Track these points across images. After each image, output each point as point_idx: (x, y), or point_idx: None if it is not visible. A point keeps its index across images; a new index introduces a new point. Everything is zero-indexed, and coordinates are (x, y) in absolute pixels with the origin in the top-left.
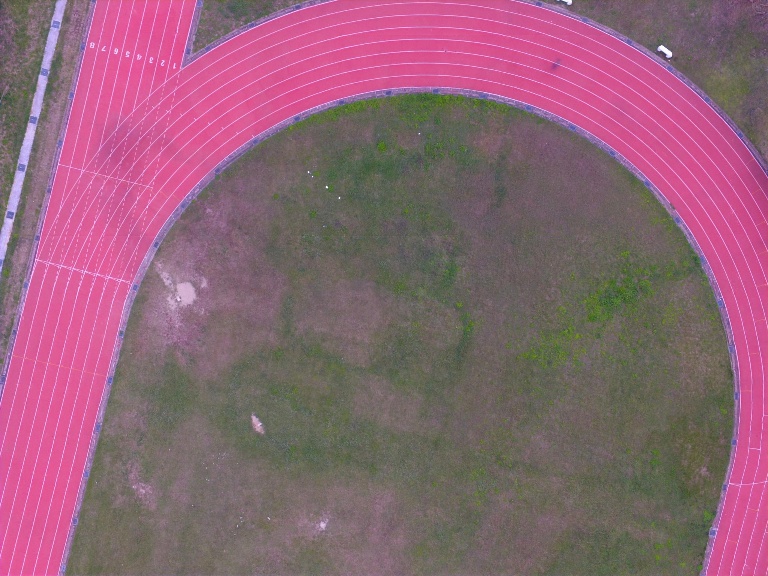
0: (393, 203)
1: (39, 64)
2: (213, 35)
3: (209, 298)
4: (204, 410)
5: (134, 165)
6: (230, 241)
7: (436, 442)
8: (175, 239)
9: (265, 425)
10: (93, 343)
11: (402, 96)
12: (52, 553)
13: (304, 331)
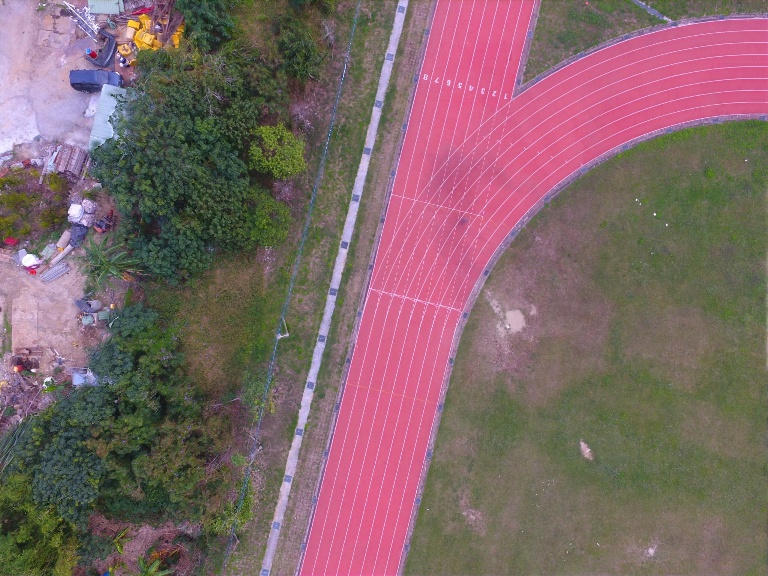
0: (720, 229)
1: (374, 96)
2: (543, 65)
3: (538, 325)
4: (534, 437)
5: (465, 194)
6: (559, 269)
7: (764, 467)
8: (505, 267)
9: (594, 451)
10: (424, 371)
11: (729, 123)
12: None
13: (632, 357)
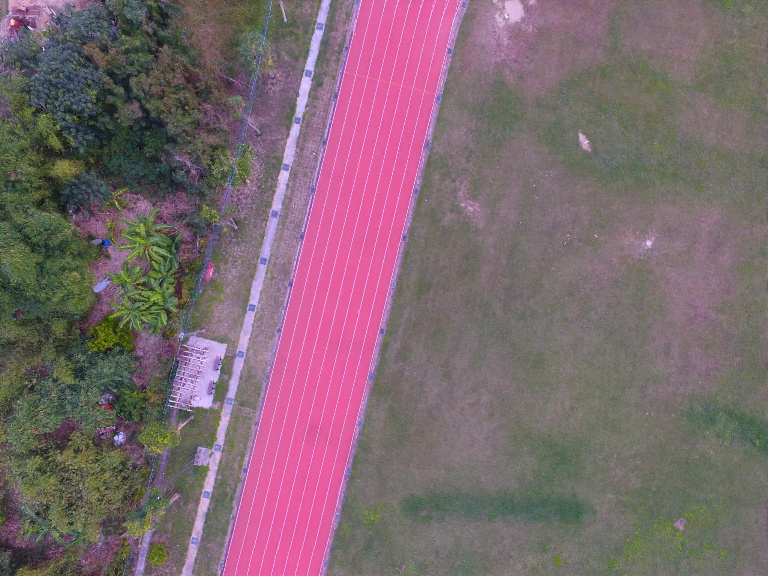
0: None
1: None
2: None
3: (537, 15)
4: (532, 127)
5: None
6: None
7: (762, 159)
8: None
9: (592, 142)
10: (422, 61)
11: None
12: (383, 270)
13: (631, 48)
